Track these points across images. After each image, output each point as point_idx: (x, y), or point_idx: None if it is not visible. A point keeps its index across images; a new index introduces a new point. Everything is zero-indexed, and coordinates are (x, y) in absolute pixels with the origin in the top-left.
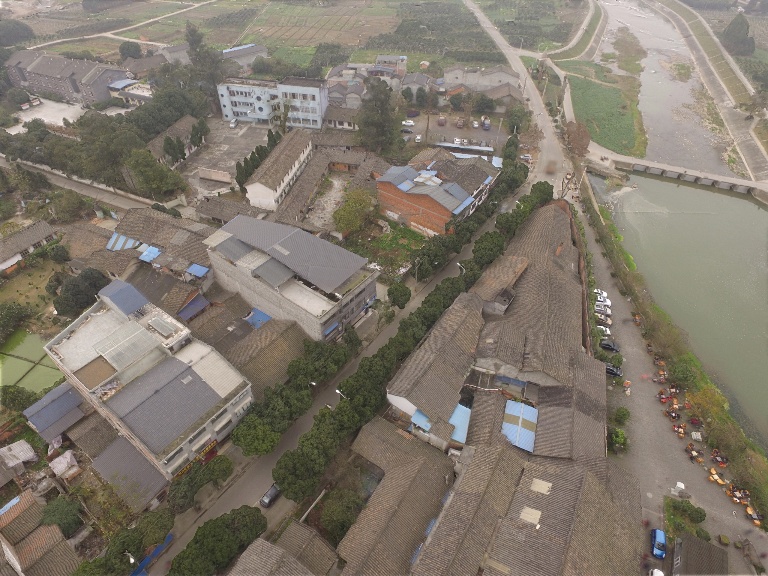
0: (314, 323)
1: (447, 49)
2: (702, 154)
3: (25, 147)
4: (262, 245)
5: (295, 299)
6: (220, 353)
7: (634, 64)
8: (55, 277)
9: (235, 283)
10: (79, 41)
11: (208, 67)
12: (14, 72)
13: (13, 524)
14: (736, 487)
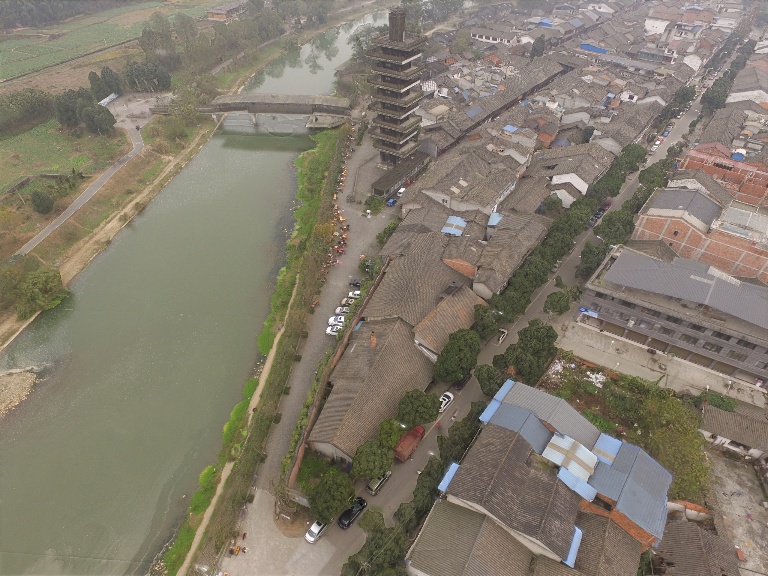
0: None
1: None
2: None
3: None
4: (728, 285)
5: None
6: None
7: None
8: None
9: None
10: None
11: None
12: None
13: None
14: None
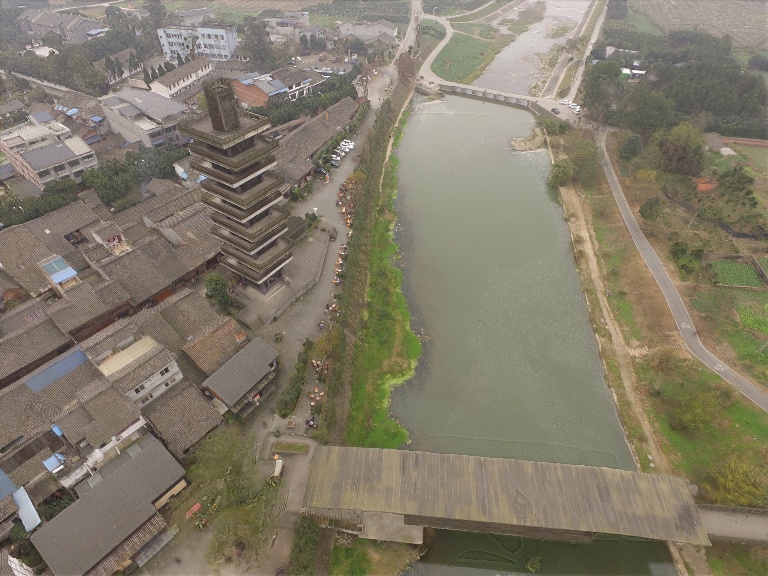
0: (146, 136)
1: (365, 14)
2: (516, 83)
3: (16, 63)
4: (128, 98)
5: (139, 125)
6: None
7: (522, 26)
8: None
9: (117, 125)
10: (82, 9)
11: (153, 17)
12: (24, 24)
13: None
14: (350, 214)
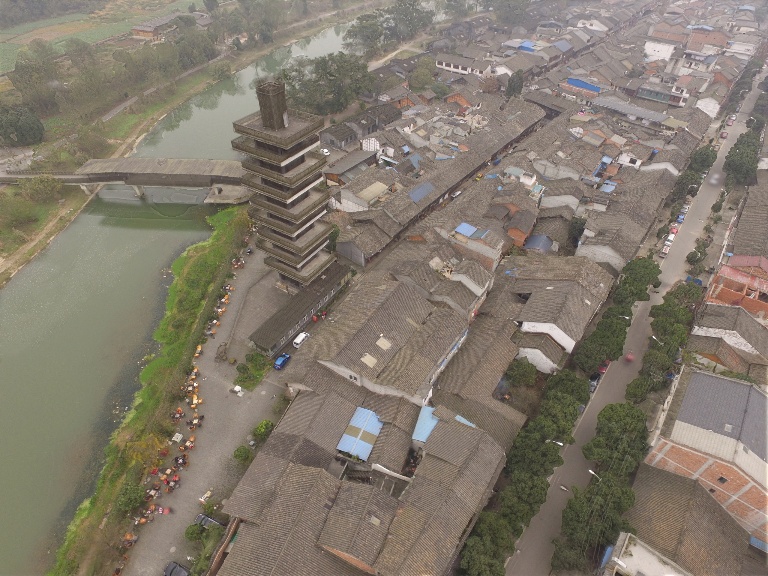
0: None
1: None
2: None
3: None
4: None
5: None
6: (748, 559)
7: None
8: None
9: None
10: None
11: None
12: None
13: (766, 372)
14: None
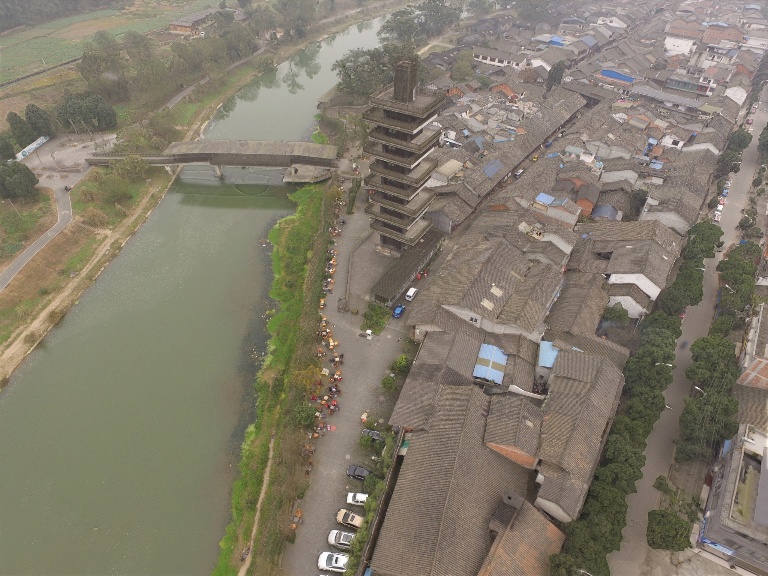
0: None
1: None
2: None
3: None
4: None
5: None
6: None
7: None
8: None
9: None
10: None
11: None
12: None
13: None
14: None
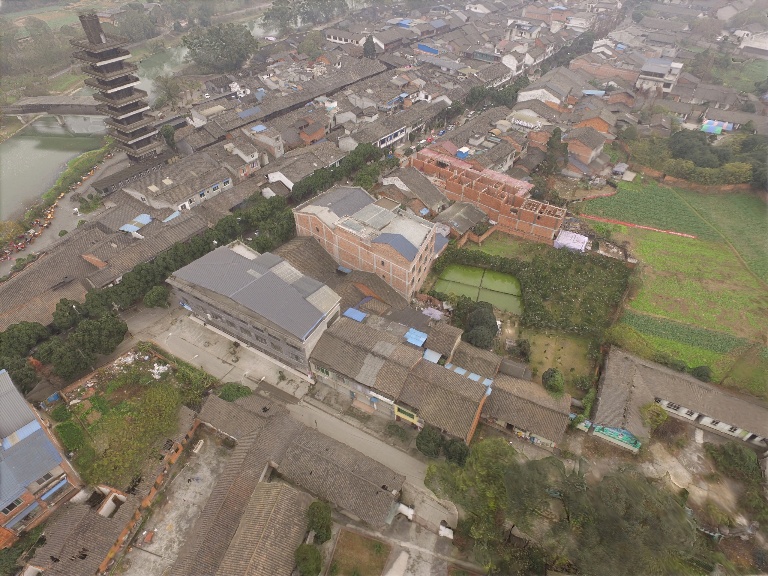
0: None
1: None
2: None
3: None
4: (274, 279)
5: None
6: (328, 272)
7: None
8: (523, 344)
9: None
10: None
11: None
12: None
13: None
14: None
